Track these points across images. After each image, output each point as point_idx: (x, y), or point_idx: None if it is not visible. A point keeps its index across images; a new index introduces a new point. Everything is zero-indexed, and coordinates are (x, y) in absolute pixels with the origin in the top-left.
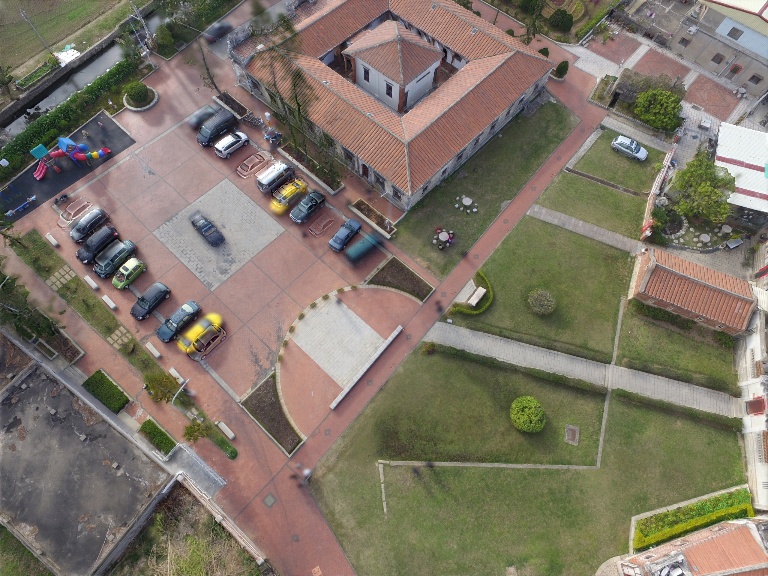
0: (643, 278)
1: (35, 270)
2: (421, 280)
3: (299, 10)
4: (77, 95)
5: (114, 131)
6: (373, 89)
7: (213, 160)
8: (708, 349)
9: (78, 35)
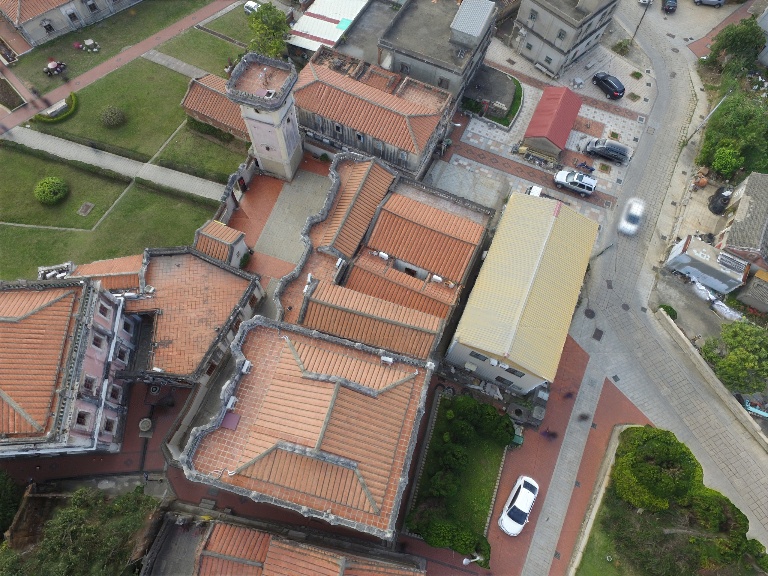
0: None
1: None
2: (18, 96)
3: None
4: None
5: None
6: None
7: None
8: (237, 157)
9: None
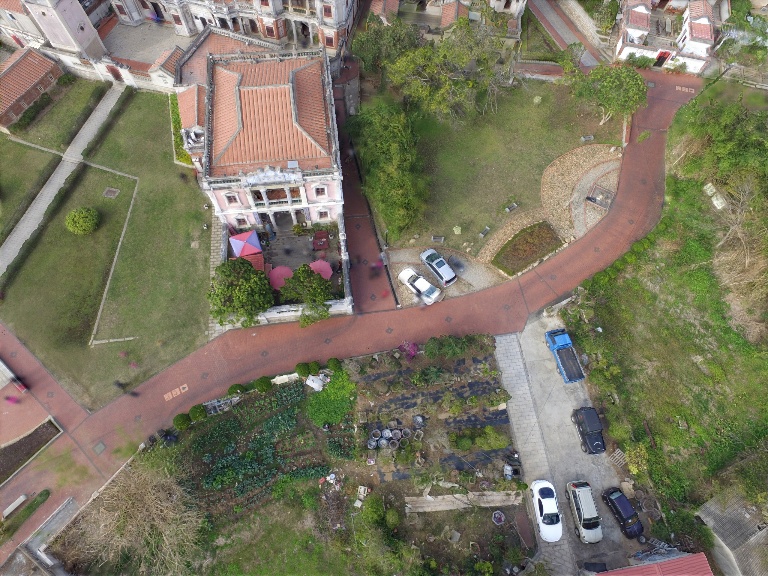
0: None
1: None
2: None
3: None
4: None
5: None
6: None
7: None
8: (72, 92)
9: None
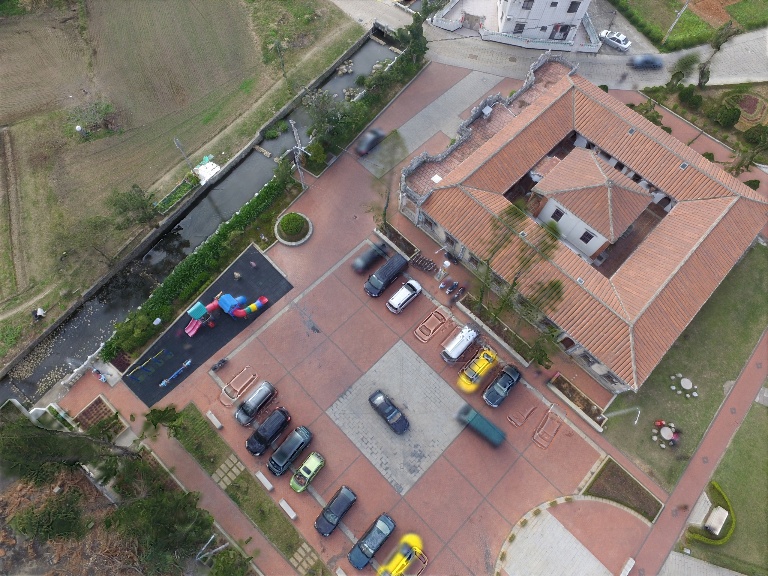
0: None
1: (198, 460)
2: None
3: (473, 128)
4: (226, 228)
5: (268, 272)
6: (561, 229)
7: (383, 314)
8: None
9: (215, 143)
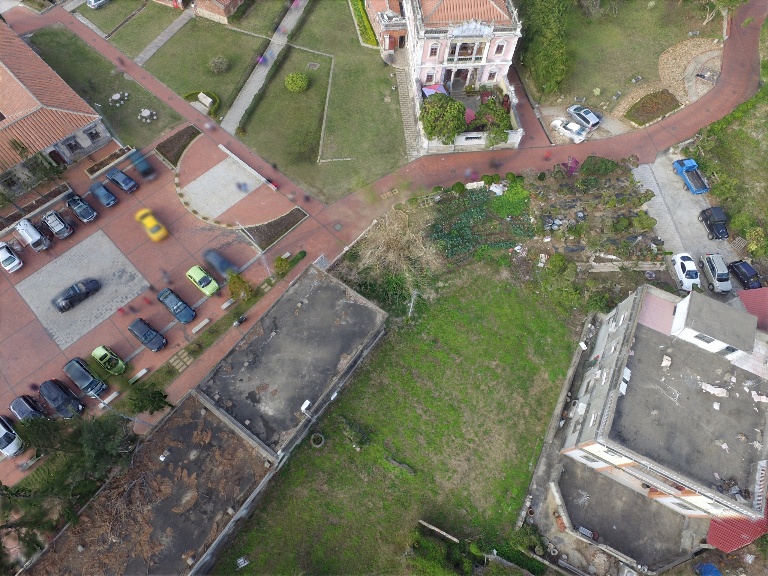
0: (214, 3)
1: None
2: None
3: None
4: None
5: None
6: None
7: None
8: None
9: None
